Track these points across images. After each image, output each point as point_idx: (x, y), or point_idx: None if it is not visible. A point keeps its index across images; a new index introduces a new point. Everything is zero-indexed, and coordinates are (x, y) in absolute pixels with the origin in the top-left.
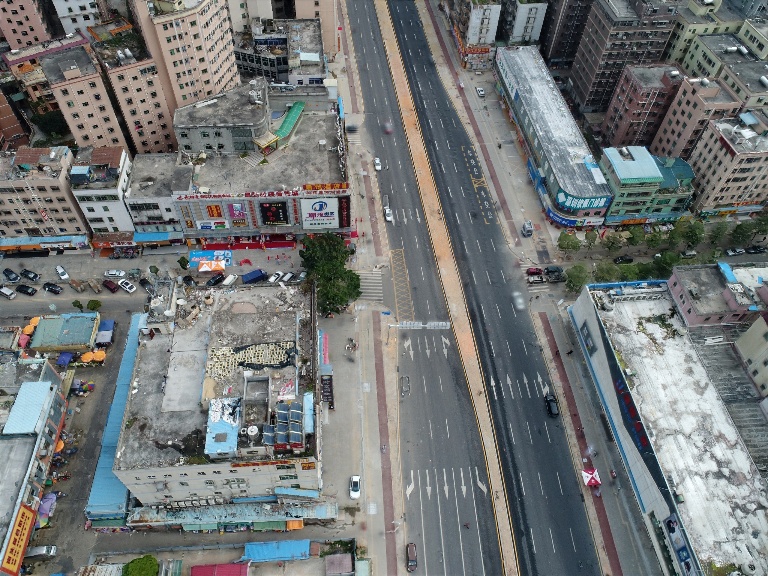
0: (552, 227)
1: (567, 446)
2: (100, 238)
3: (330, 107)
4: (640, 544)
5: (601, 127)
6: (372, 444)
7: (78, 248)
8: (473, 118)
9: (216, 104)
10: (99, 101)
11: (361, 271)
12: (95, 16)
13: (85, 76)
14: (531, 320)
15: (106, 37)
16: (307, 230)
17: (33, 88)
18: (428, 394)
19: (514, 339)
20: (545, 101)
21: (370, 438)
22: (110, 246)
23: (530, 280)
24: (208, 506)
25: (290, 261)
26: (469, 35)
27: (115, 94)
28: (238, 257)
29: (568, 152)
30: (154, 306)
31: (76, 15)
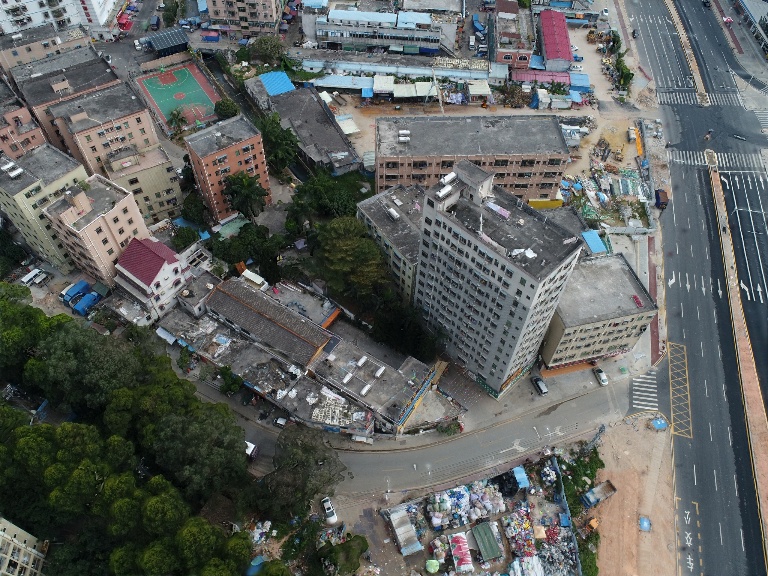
0: None
1: (714, 15)
2: None
3: None
4: (752, 41)
5: None
6: (611, 5)
7: None
8: None
9: None
10: None
11: None
12: None
13: None
14: None
15: None
16: None
17: None
18: None
19: None
20: None
21: (609, 4)
22: None
23: None
24: (538, 5)
25: None
26: None
27: None
28: None
29: None
30: None
31: None
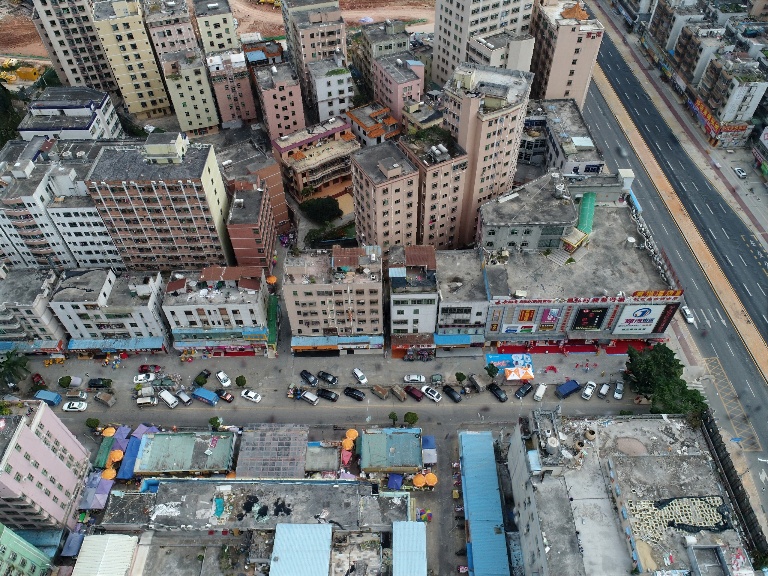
0: None
1: None
2: (400, 340)
3: (618, 197)
4: None
5: None
6: None
7: (369, 348)
8: (742, 203)
9: (519, 199)
10: (410, 198)
11: None
12: (350, 99)
13: (407, 174)
14: None
15: None
16: (615, 335)
17: (302, 175)
18: None
19: None
20: None
21: None
22: (408, 348)
23: None
24: None
25: (597, 369)
26: (726, 112)
27: (422, 190)
28: (539, 362)
29: None
30: (553, 446)
31: (334, 99)
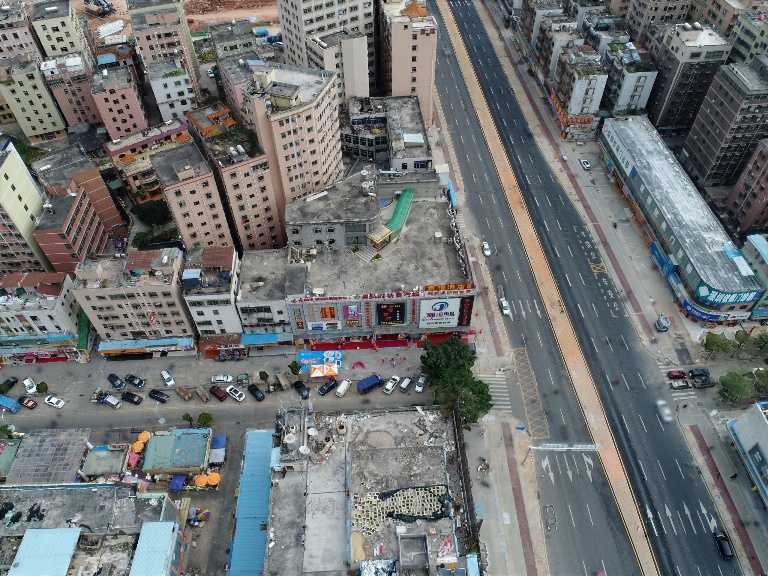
0: (688, 320)
1: None
2: (207, 341)
3: (439, 193)
4: None
5: (726, 203)
6: None
7: (182, 349)
8: (582, 194)
9: (327, 197)
10: (210, 199)
11: (483, 374)
12: (192, 100)
13: (199, 176)
14: (682, 434)
15: (217, 132)
16: (423, 329)
17: (134, 178)
18: (577, 528)
19: (666, 458)
20: (667, 178)
21: None
22: (217, 349)
23: (674, 385)
24: None
25: (405, 363)
26: (571, 105)
27: (225, 191)
28: (349, 358)
29: (703, 238)
30: (289, 443)
31: (174, 101)
